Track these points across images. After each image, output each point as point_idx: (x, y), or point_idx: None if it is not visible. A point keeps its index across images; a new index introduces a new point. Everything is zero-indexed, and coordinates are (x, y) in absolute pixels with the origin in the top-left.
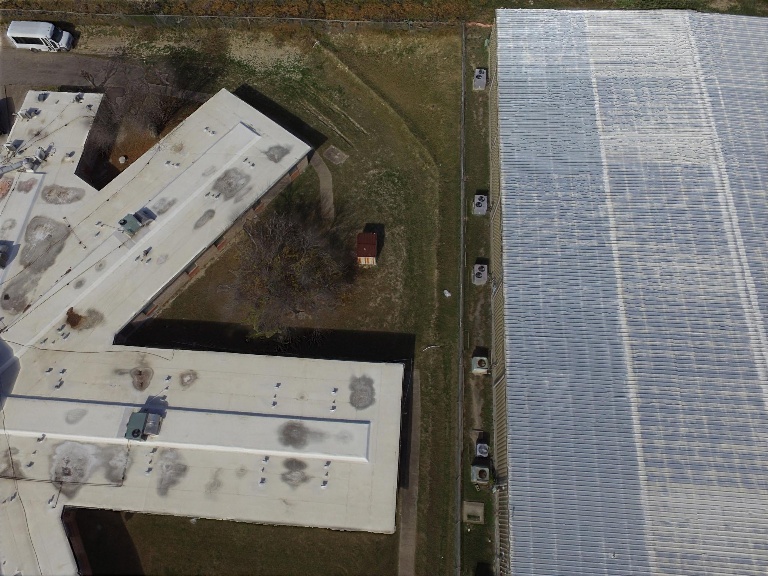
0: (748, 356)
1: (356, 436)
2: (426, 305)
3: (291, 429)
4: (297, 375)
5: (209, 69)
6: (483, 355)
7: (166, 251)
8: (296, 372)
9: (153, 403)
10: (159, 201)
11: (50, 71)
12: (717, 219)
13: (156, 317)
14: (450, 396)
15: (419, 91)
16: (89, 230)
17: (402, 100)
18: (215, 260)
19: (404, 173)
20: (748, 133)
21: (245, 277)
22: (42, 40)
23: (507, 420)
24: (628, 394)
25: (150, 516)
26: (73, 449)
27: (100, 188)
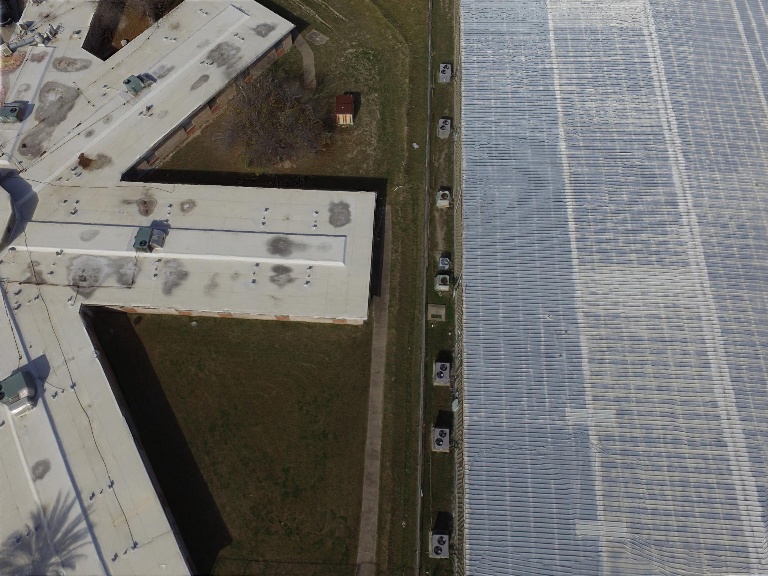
0: (667, 170)
1: (334, 246)
2: (397, 155)
3: (278, 242)
4: (283, 202)
5: None
6: None
7: (166, 108)
8: (282, 200)
9: (157, 225)
10: (159, 68)
11: None
12: (646, 68)
13: (158, 168)
14: (417, 225)
15: None
16: (96, 92)
17: None
18: (210, 122)
19: (378, 51)
20: (676, 2)
21: (237, 125)
22: None
23: (462, 222)
24: (565, 199)
25: (156, 321)
26: (88, 261)
27: (105, 59)
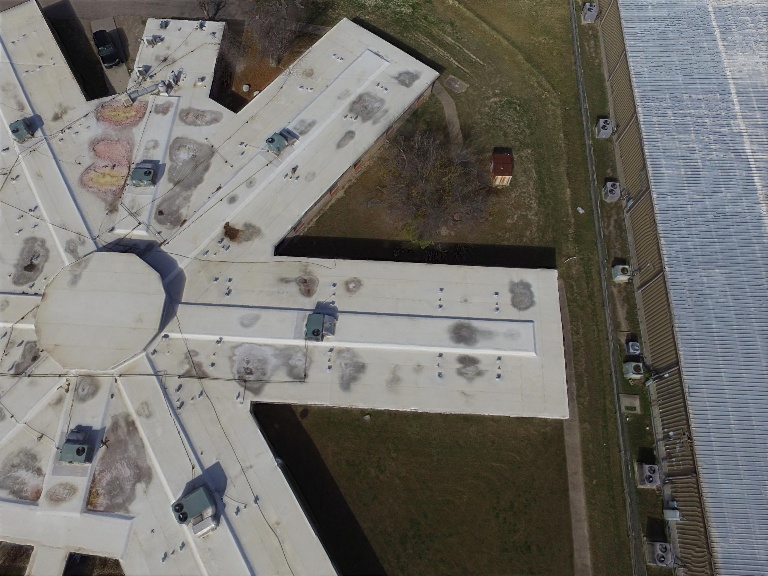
0: None
1: (523, 333)
2: (562, 221)
3: (461, 328)
4: (458, 281)
5: (319, 2)
6: (622, 265)
7: (313, 169)
8: (456, 278)
9: (323, 308)
10: (299, 122)
11: (158, 3)
12: None
13: (302, 235)
14: (595, 302)
15: (529, 25)
16: (233, 150)
17: (514, 33)
18: (353, 182)
19: (524, 101)
20: None
21: (397, 191)
22: None
23: (672, 311)
24: None
25: (324, 414)
26: (251, 350)
27: (237, 111)
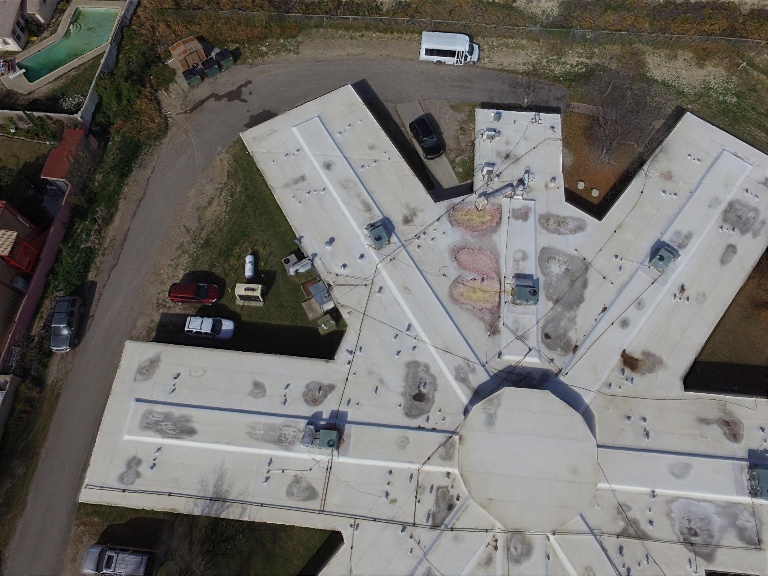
0: None
1: None
2: None
3: None
4: None
5: (634, 89)
6: None
7: (702, 289)
8: None
9: (757, 457)
10: (675, 234)
11: (462, 86)
12: None
13: None
14: None
15: None
16: (608, 264)
17: None
18: None
19: None
20: None
21: None
22: (457, 53)
23: None
24: None
25: None
26: (690, 507)
27: (600, 218)
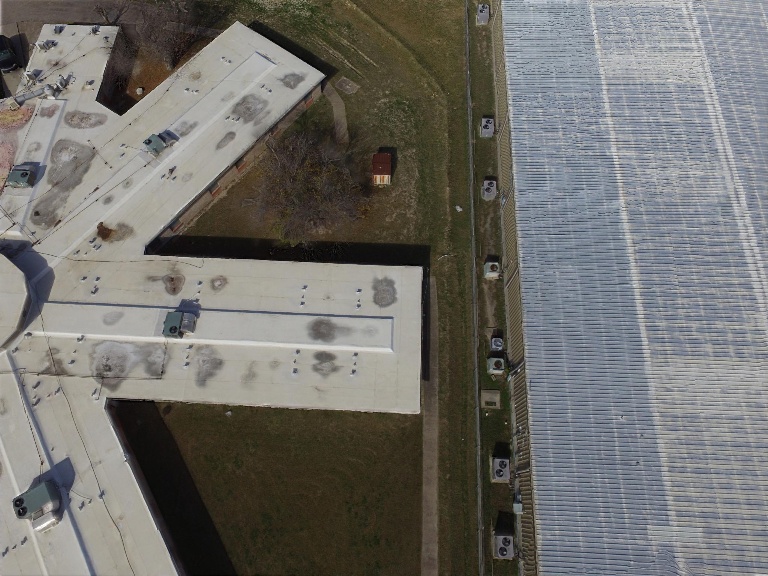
0: (738, 247)
1: (381, 329)
2: (439, 219)
3: (320, 325)
4: (323, 278)
5: (220, 7)
6: (494, 262)
7: (190, 170)
8: (321, 276)
9: (186, 306)
10: (181, 124)
11: (62, 9)
12: (708, 130)
13: (182, 234)
14: (465, 299)
15: (425, 27)
16: (114, 152)
17: (409, 35)
18: (236, 182)
19: (414, 101)
20: (734, 55)
21: (269, 191)
22: None
23: (522, 307)
24: (631, 281)
25: (187, 411)
26: (112, 348)
27: (122, 113)
